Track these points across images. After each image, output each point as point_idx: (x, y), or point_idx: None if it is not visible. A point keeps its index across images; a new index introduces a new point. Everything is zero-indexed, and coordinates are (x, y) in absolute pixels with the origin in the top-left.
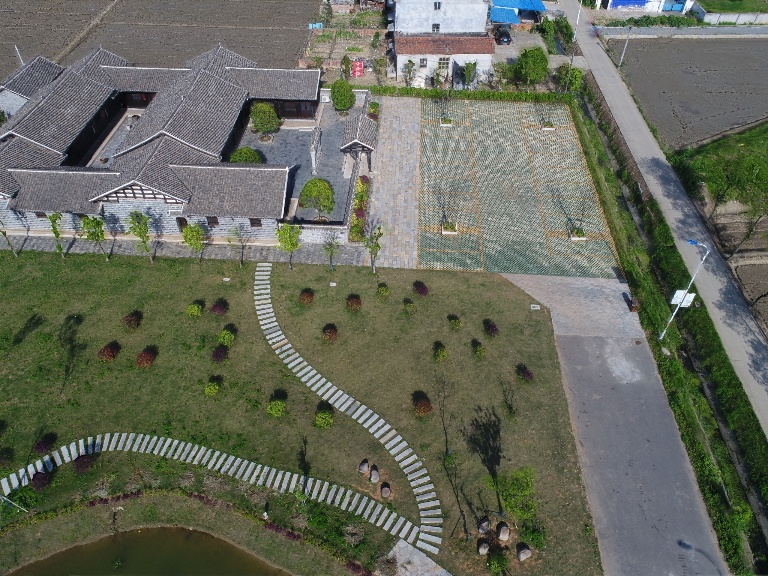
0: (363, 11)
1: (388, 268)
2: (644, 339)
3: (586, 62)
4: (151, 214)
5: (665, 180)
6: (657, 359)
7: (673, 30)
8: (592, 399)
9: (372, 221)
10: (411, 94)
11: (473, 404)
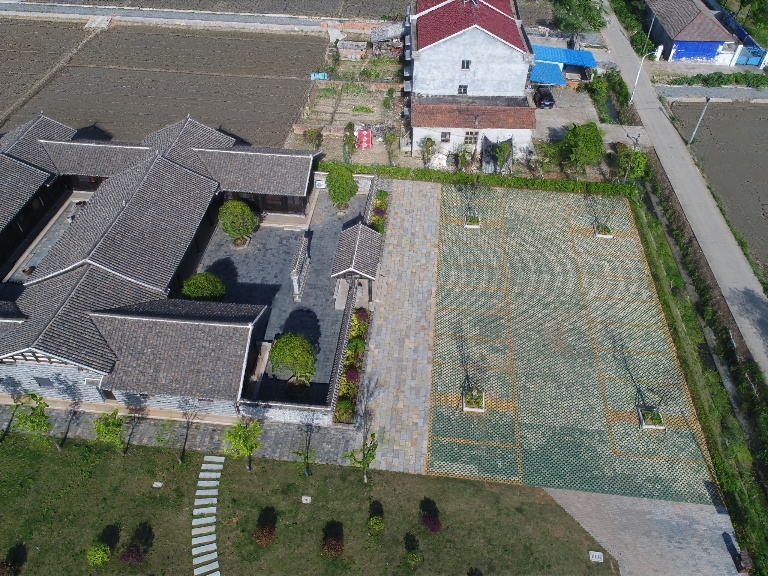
0: (376, 57)
1: (386, 472)
2: None
3: (647, 135)
4: (62, 380)
5: (766, 328)
6: None
7: (751, 92)
8: None
9: (368, 384)
10: (429, 178)
11: None
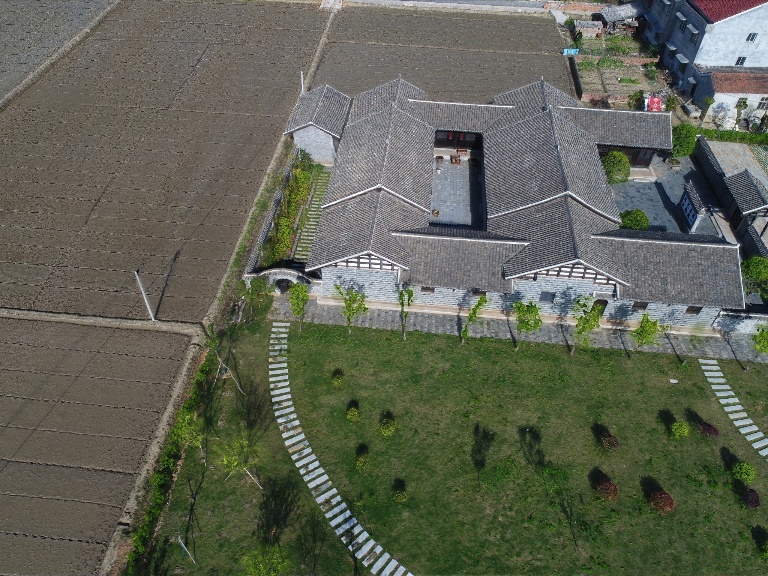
0: (610, 35)
1: None
2: None
3: None
4: (567, 294)
5: None
6: None
7: None
8: None
9: None
10: (734, 139)
11: None
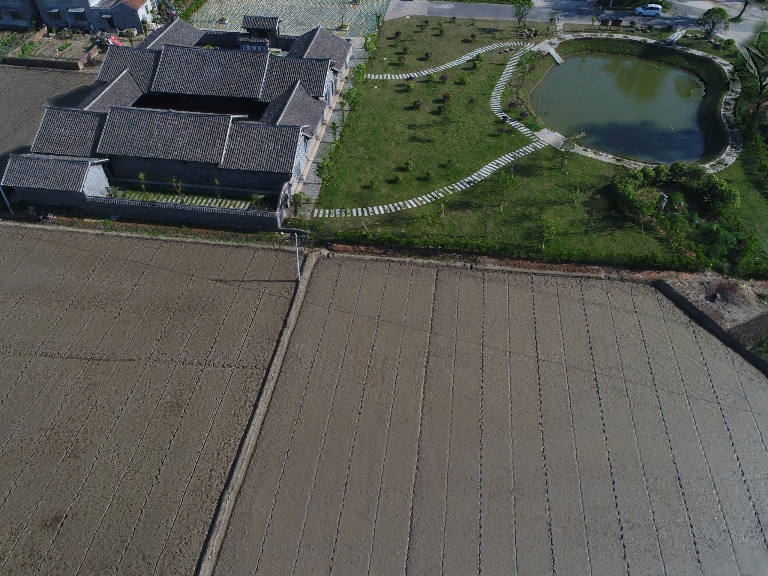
0: None
1: None
2: (430, 1)
3: None
4: None
5: None
6: (441, 0)
7: None
8: (463, 13)
9: None
10: None
11: (468, 31)
